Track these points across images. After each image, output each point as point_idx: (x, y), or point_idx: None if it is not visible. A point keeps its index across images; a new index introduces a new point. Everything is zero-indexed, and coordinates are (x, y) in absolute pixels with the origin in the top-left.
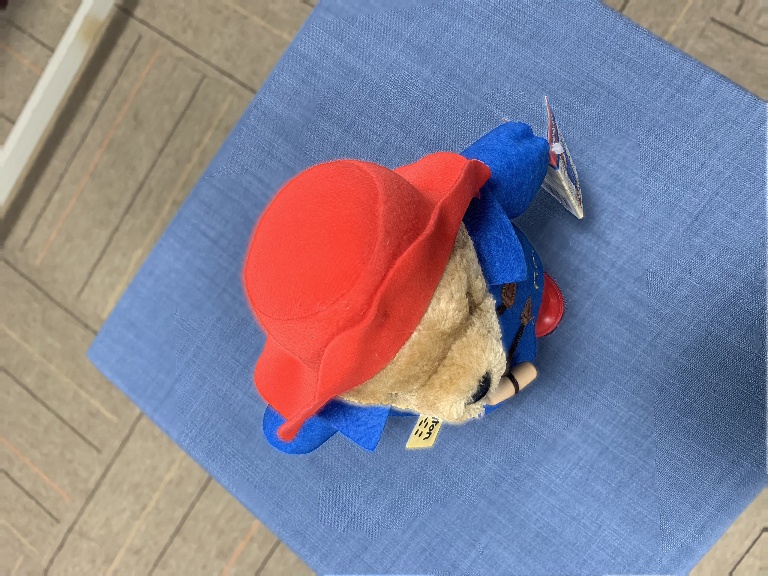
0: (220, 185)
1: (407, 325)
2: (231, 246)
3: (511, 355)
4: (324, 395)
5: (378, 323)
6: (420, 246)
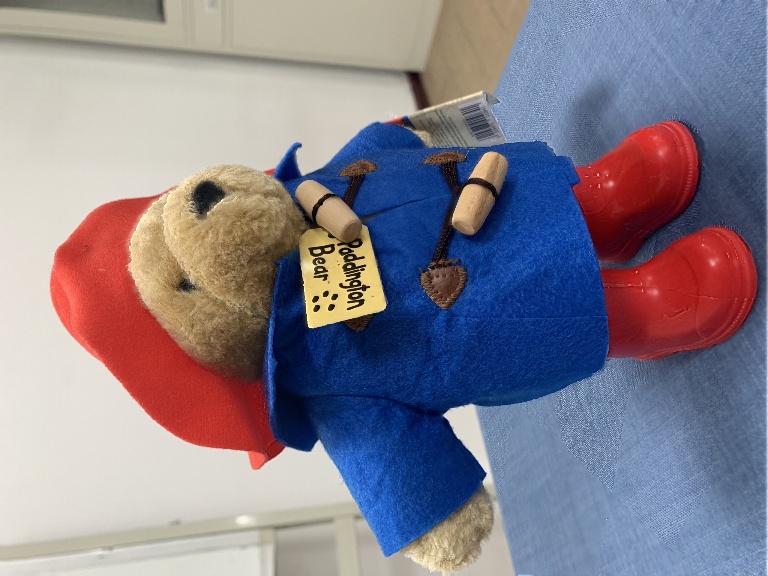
0: (504, 502)
1: (121, 239)
2: (542, 537)
3: (450, 183)
4: (84, 329)
5: (77, 254)
6: (96, 208)
